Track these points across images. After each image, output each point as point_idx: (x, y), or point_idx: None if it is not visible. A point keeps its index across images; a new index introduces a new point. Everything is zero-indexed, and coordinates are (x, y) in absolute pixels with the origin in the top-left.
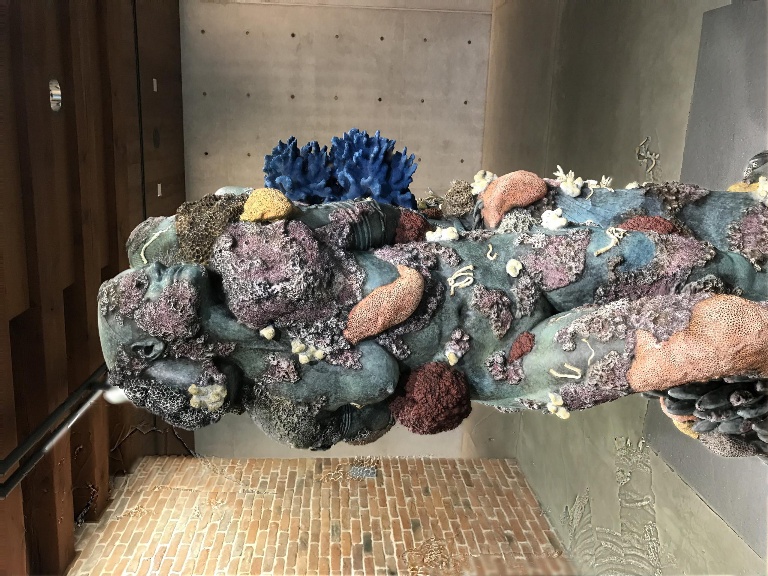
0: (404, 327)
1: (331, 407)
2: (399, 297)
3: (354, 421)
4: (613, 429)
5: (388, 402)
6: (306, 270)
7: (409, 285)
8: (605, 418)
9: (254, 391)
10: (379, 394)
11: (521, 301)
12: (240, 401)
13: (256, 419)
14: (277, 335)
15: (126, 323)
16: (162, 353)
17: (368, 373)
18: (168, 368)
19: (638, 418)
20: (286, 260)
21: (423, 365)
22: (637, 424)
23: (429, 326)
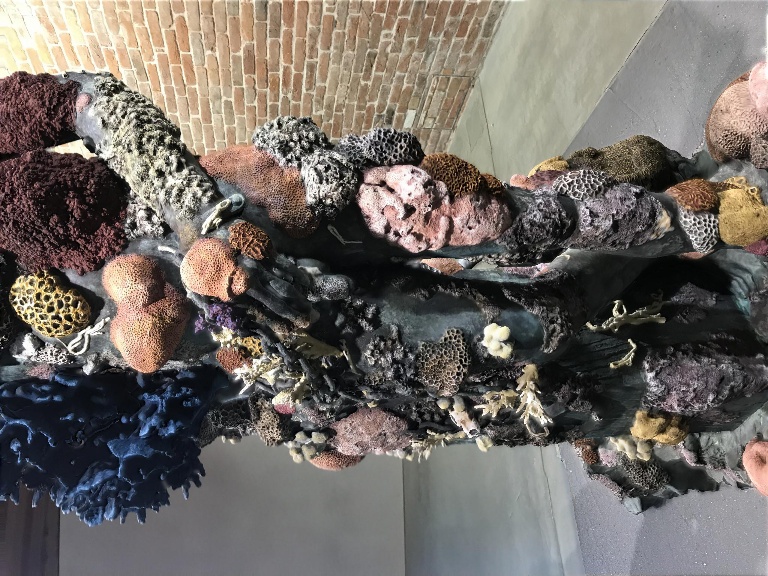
0: None
1: None
2: None
3: None
4: None
5: None
6: None
7: None
8: None
9: None
10: None
11: None
12: None
13: None
14: None
15: None
16: None
17: None
18: None
19: None
20: None
21: None
22: None
23: None
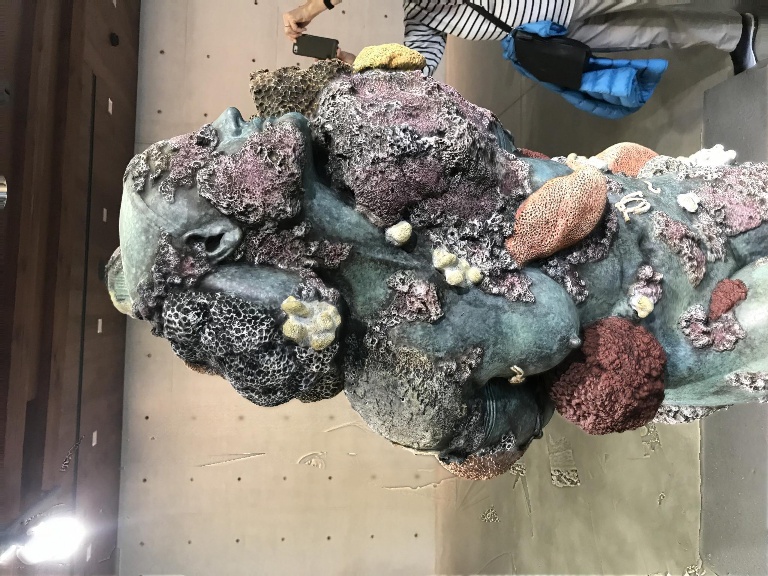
0: (579, 253)
1: (483, 372)
2: (585, 191)
3: (499, 415)
4: (644, 565)
5: (554, 377)
6: (468, 121)
7: (595, 177)
8: (631, 553)
9: (366, 342)
10: (558, 347)
11: (709, 240)
12: (340, 363)
13: (365, 394)
14: (411, 240)
15: (179, 196)
16: (235, 250)
17: (544, 309)
18: (244, 274)
19: (677, 544)
20: (437, 107)
21: (600, 320)
22: (677, 552)
23: (607, 258)
